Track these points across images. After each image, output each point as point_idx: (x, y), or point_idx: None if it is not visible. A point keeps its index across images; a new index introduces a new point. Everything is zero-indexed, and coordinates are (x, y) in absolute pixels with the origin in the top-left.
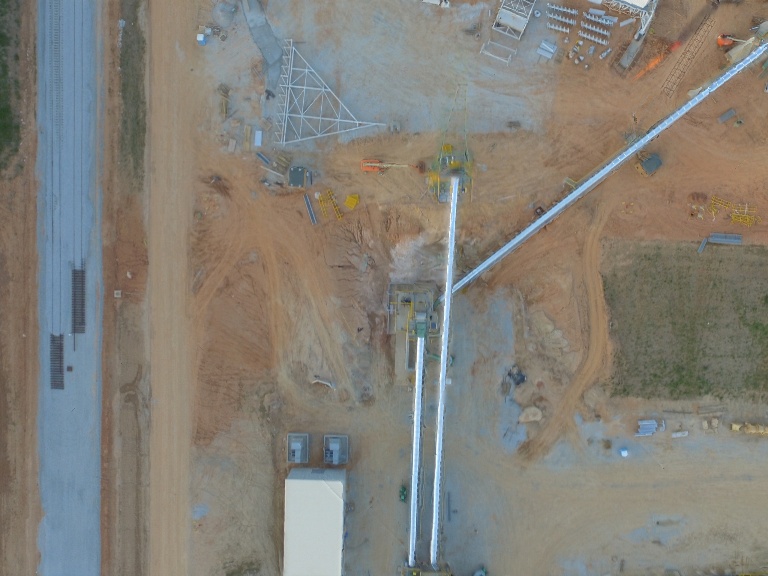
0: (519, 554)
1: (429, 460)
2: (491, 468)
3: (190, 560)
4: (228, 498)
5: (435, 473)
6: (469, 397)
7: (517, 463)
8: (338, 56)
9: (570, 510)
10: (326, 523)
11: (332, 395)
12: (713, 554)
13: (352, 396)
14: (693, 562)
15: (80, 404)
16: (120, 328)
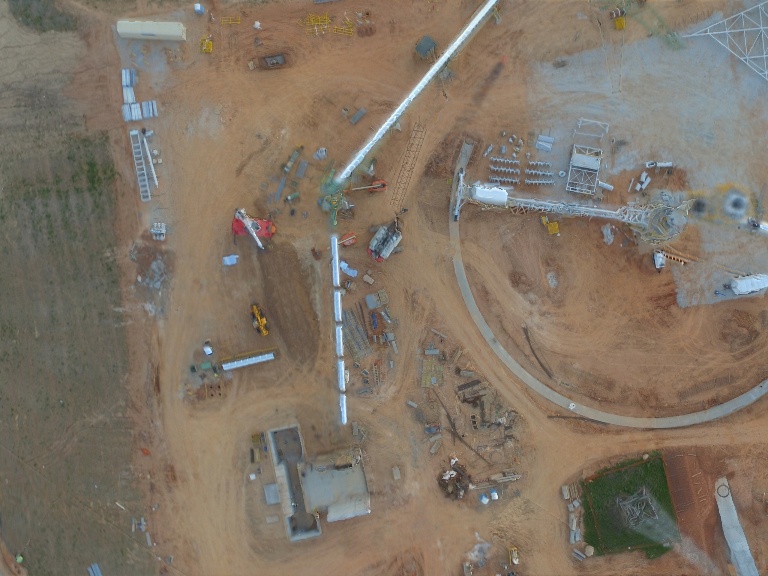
0: None
1: None
2: None
3: None
4: None
5: None
6: None
7: None
8: (740, 94)
9: None
10: None
11: None
12: None
13: None
14: None
15: None
16: None
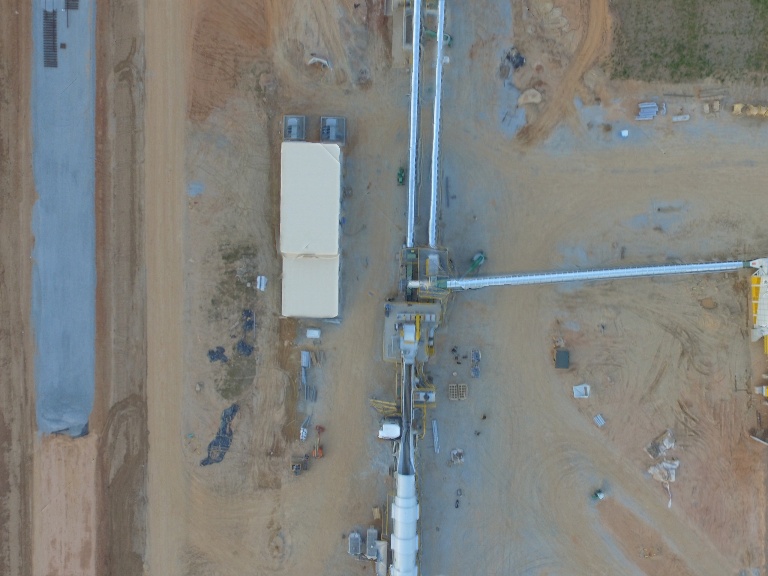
0: (519, 241)
1: (427, 130)
2: (490, 152)
3: (186, 239)
4: (224, 178)
5: (433, 145)
6: (467, 80)
7: (516, 148)
8: None
9: (570, 196)
10: (323, 186)
11: (329, 76)
12: (715, 241)
13: (349, 77)
14: (695, 250)
15: (74, 82)
16: (114, 5)
